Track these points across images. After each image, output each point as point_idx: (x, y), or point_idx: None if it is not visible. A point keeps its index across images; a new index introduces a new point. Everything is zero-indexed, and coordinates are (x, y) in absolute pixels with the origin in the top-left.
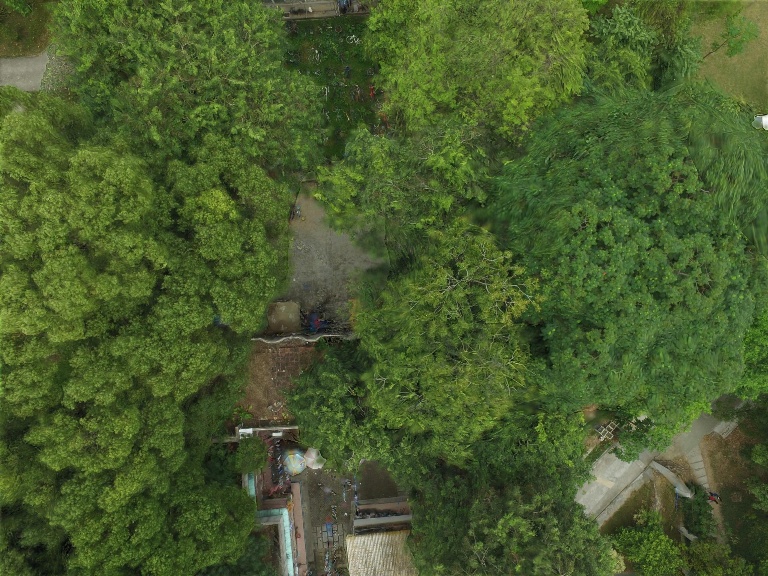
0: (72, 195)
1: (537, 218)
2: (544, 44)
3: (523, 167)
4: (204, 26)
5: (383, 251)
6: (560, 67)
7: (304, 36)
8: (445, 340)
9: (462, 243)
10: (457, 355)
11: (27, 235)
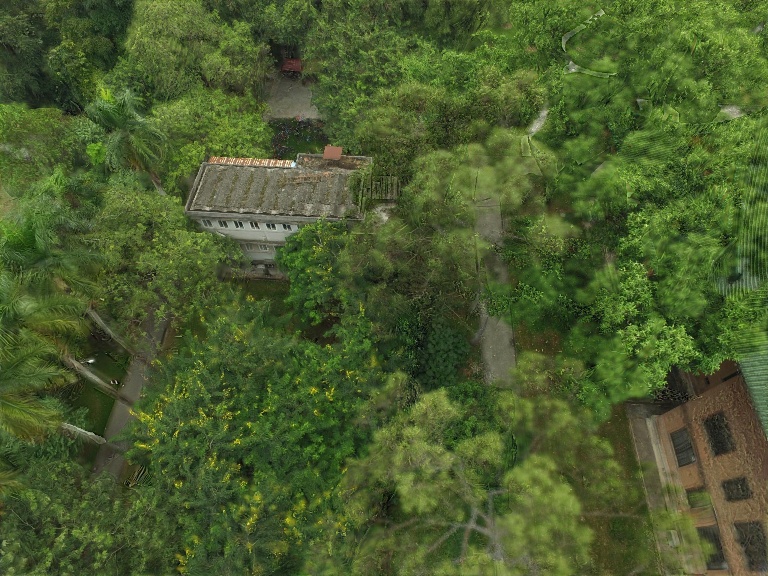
0: None
1: None
2: None
3: None
4: None
5: (298, 102)
6: None
7: None
8: None
9: None
10: None
11: None
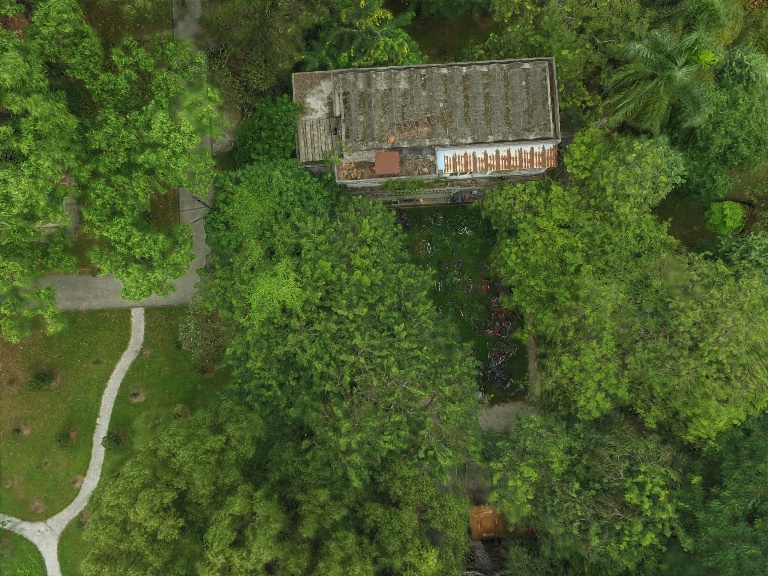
0: None
1: None
2: (739, 372)
3: (725, 508)
4: (365, 305)
5: None
6: (754, 393)
7: (415, 228)
8: None
9: None
10: None
11: None
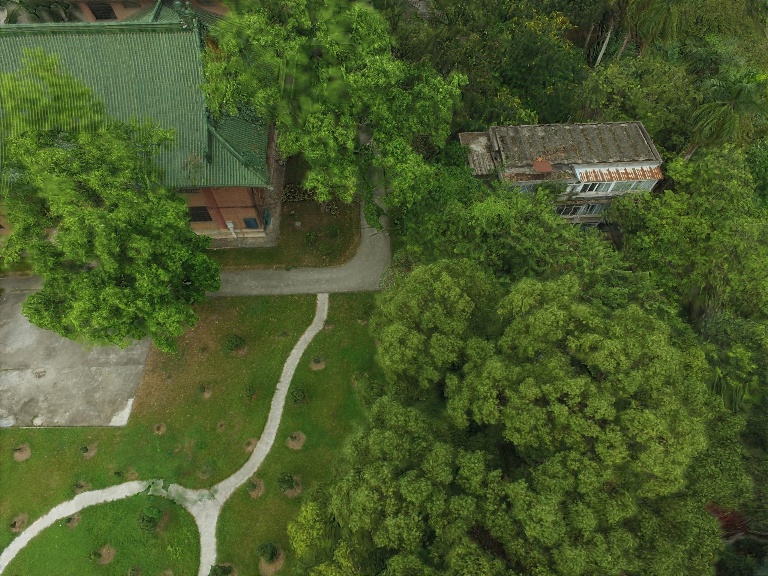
0: None
1: None
2: None
3: None
4: None
5: None
6: None
7: None
8: None
9: None
10: None
11: (636, 371)
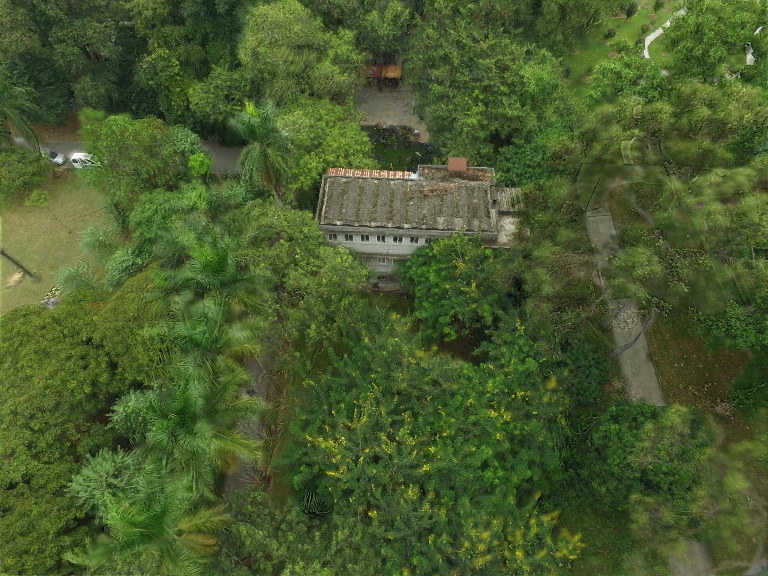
0: None
1: None
2: None
3: None
4: None
5: (377, 109)
6: (270, 4)
7: None
8: None
9: None
10: None
11: None
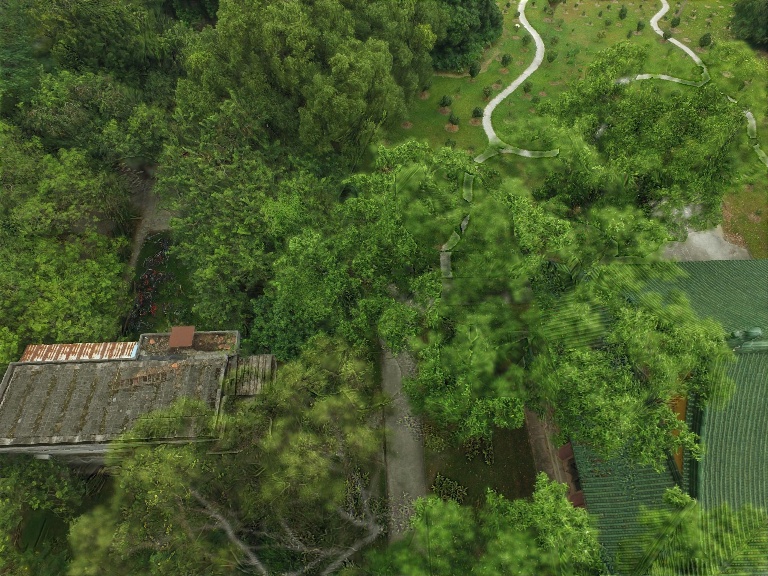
0: (236, 1)
1: (8, 40)
2: None
3: (7, 80)
4: None
5: None
6: None
7: None
8: (88, 6)
9: (47, 6)
10: (84, 2)
11: None
